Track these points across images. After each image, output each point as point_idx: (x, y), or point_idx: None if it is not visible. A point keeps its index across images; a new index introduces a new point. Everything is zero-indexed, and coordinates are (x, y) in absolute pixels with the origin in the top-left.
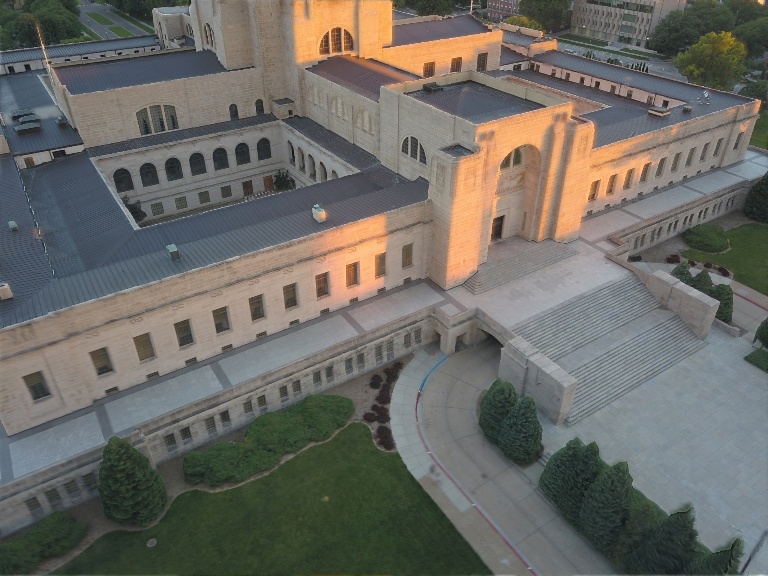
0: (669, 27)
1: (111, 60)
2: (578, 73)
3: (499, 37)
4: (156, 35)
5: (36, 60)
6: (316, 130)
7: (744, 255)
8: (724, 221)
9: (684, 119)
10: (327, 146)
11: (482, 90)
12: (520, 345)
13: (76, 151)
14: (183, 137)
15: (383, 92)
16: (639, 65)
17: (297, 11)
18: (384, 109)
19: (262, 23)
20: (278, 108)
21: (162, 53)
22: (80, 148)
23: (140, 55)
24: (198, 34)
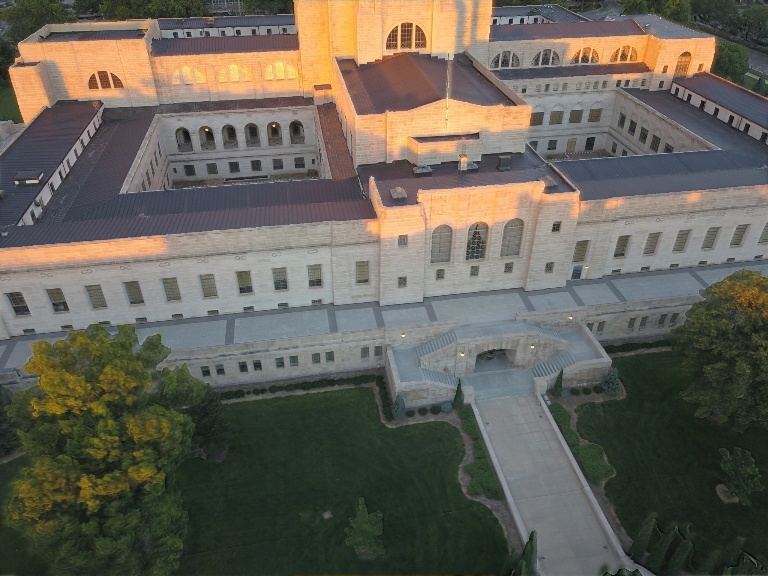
0: None
1: None
2: None
3: None
4: None
5: None
6: None
7: None
8: None
9: None
10: None
11: None
12: (4, 121)
13: None
14: None
15: None
16: None
17: None
18: None
19: None
20: None
21: None
22: None
23: None
24: None
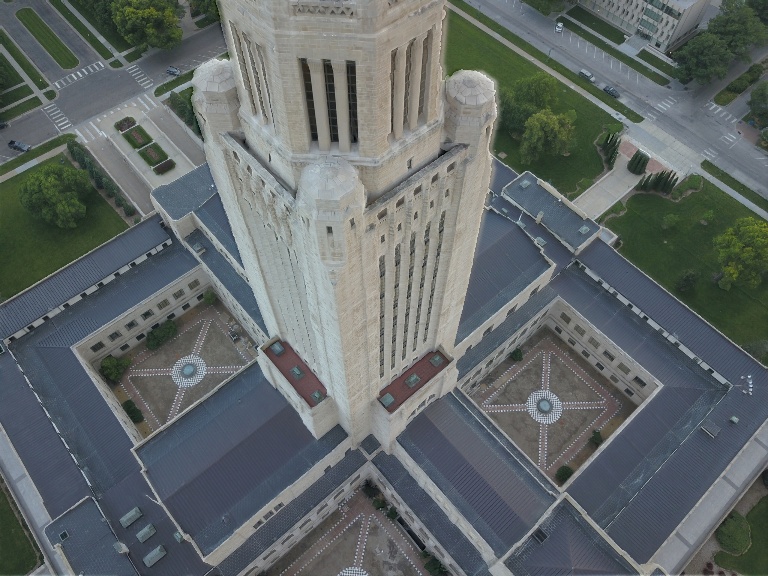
0: (697, 59)
1: (185, 414)
2: (627, 300)
3: (553, 269)
4: (158, 214)
5: (53, 310)
6: (410, 484)
7: (761, 553)
8: (747, 495)
9: (732, 444)
10: (429, 521)
11: (579, 521)
12: None
13: (208, 572)
14: (292, 517)
15: (503, 569)
16: (669, 172)
17: (393, 421)
18: (502, 572)
19: (355, 422)
20: (368, 457)
21: (229, 381)
22: (211, 569)
23: (210, 395)
24: (270, 380)
